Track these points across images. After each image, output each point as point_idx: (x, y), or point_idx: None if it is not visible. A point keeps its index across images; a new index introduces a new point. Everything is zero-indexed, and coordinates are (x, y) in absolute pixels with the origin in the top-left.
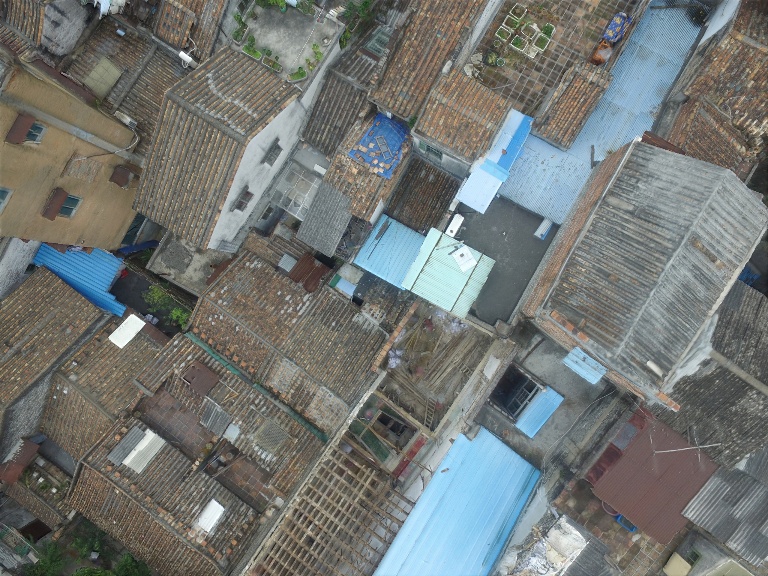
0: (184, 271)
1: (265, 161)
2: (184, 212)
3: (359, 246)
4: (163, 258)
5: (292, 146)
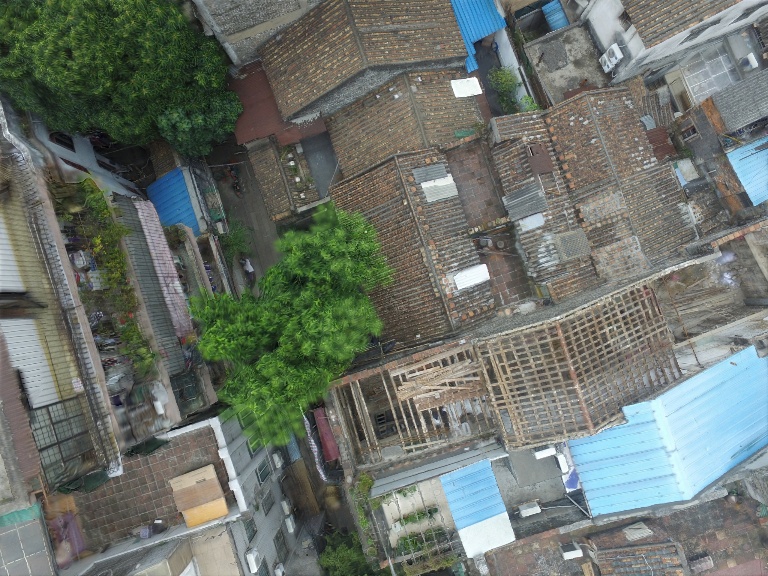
0: (552, 71)
1: (748, 11)
2: (662, 3)
3: (745, 143)
4: (542, 48)
5: (745, 24)
